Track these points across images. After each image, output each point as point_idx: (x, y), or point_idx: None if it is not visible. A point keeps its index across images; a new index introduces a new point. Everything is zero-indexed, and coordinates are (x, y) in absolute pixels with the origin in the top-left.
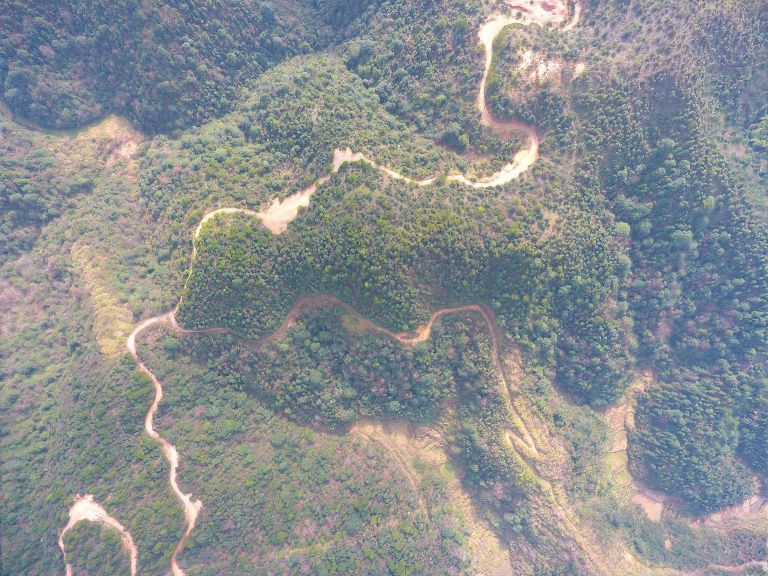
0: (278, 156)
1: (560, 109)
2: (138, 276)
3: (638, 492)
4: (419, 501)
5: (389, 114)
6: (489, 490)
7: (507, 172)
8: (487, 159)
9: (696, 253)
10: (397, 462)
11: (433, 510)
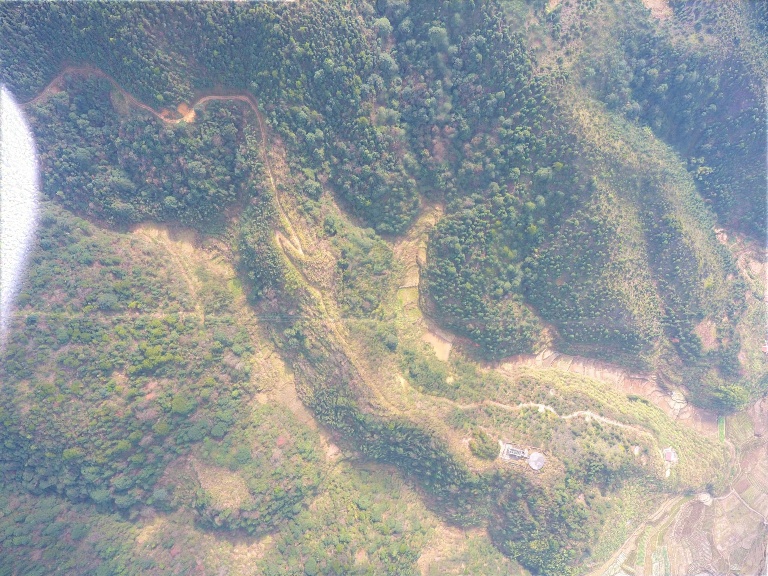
0: None
1: None
2: None
3: (429, 331)
4: (196, 306)
5: None
6: (266, 300)
7: None
8: None
9: (458, 60)
10: (178, 266)
11: (209, 315)
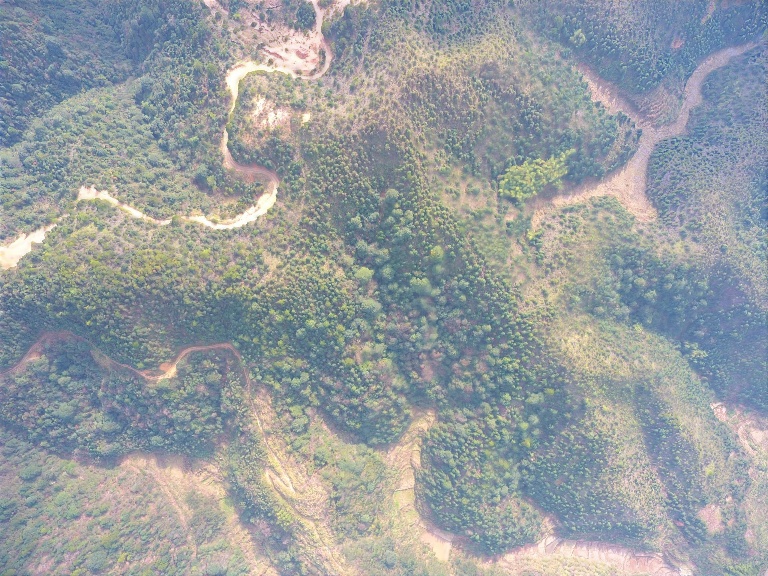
0: None
1: (291, 156)
2: None
3: (427, 531)
4: (188, 537)
5: (162, 151)
6: (258, 527)
7: (249, 215)
8: (235, 201)
9: (442, 299)
10: (167, 497)
11: (201, 547)
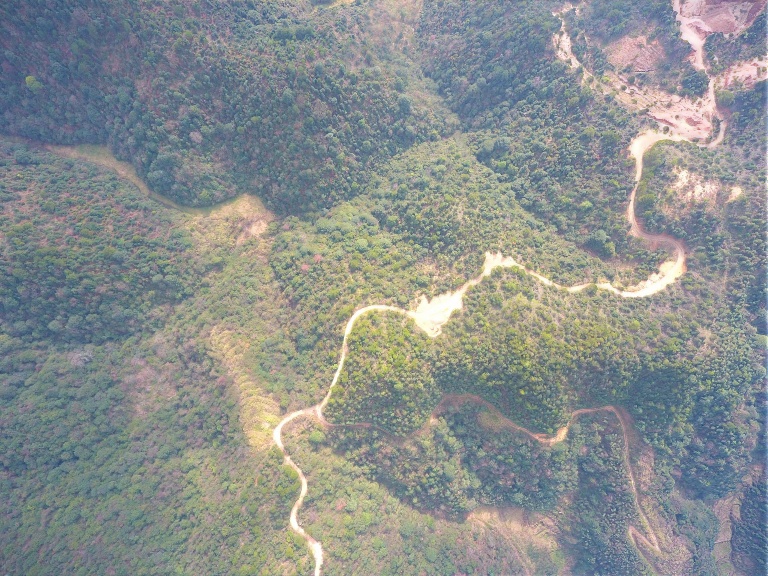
0: (418, 249)
1: (713, 228)
2: (280, 364)
3: None
4: None
5: (524, 210)
6: None
7: (653, 282)
8: (631, 267)
9: None
10: (513, 551)
11: None
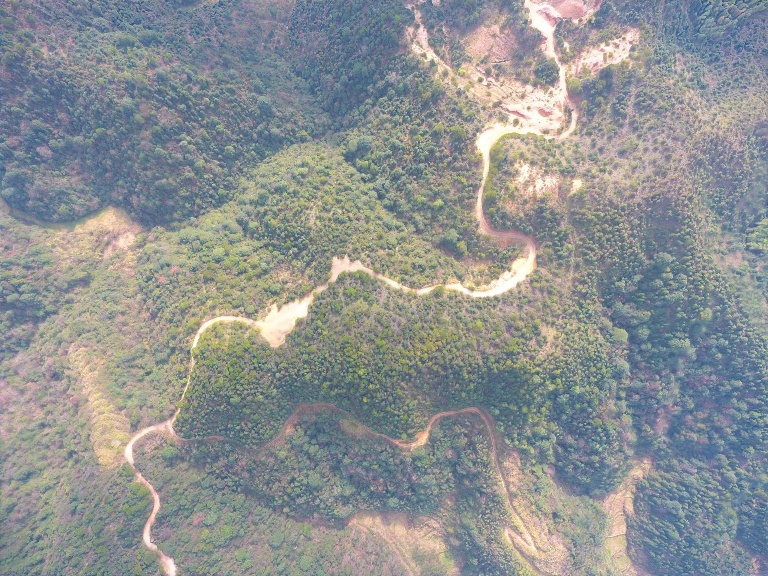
0: (276, 256)
1: (557, 222)
2: (136, 380)
3: (637, 575)
4: None
5: (387, 211)
6: None
7: (505, 280)
8: (485, 265)
9: (694, 357)
10: (396, 555)
11: None
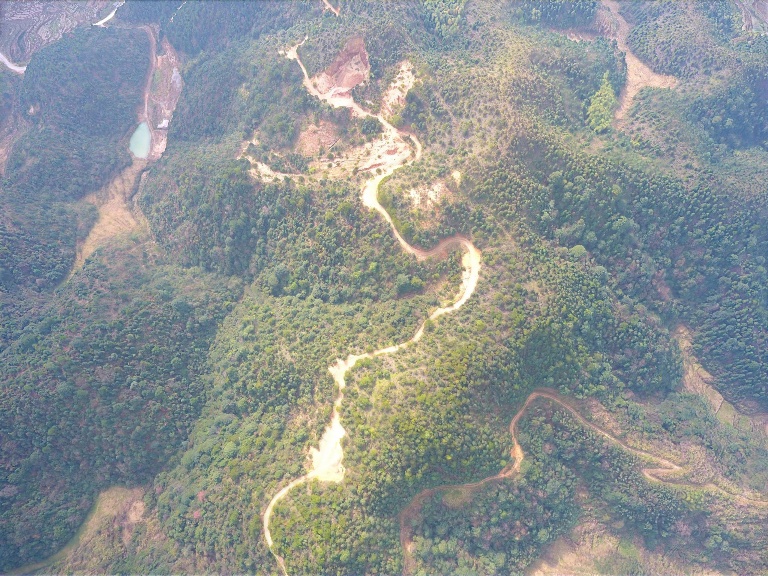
0: (280, 410)
1: (467, 210)
2: None
3: (764, 424)
4: None
5: (339, 305)
6: (675, 535)
7: (468, 279)
8: (444, 281)
9: (637, 226)
10: None
11: None
